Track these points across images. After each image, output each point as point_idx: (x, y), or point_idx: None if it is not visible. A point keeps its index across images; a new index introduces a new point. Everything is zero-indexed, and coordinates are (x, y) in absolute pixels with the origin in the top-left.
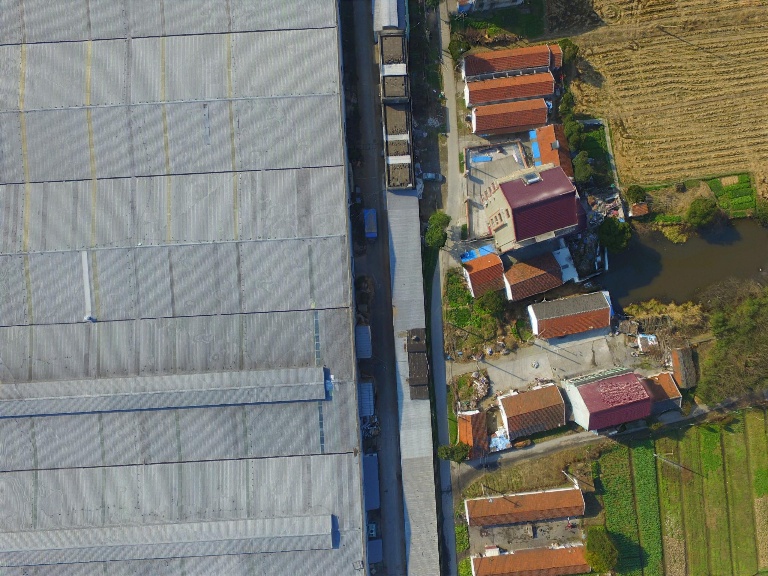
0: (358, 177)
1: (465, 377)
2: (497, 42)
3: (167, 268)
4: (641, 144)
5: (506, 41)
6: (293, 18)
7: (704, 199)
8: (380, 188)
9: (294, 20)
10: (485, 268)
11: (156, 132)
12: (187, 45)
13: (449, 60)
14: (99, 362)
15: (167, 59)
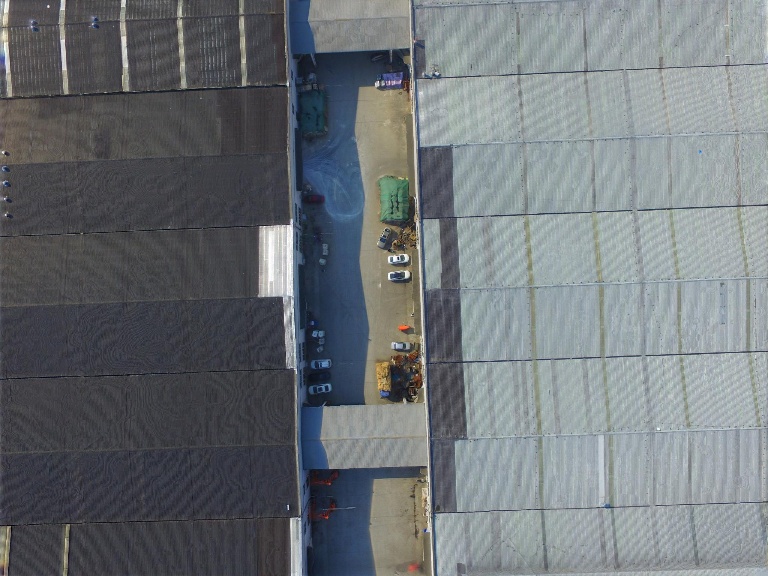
0: None
1: None
2: None
3: (686, 454)
4: None
5: None
6: None
7: None
8: None
9: None
10: None
11: (670, 310)
12: (696, 219)
13: None
14: (617, 551)
15: (677, 234)
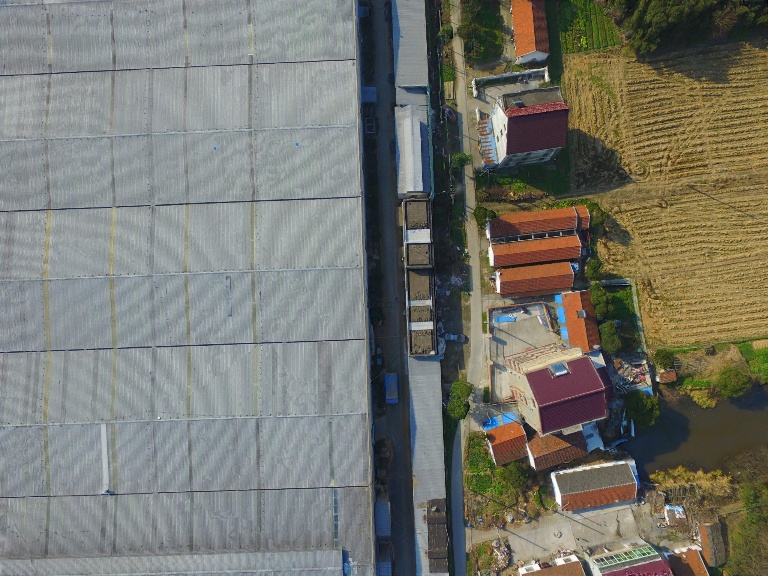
0: (379, 336)
1: (485, 545)
2: (522, 200)
3: (186, 442)
4: (669, 305)
5: (532, 198)
6: (317, 187)
7: (735, 373)
8: (401, 348)
9: (318, 189)
10: (508, 439)
11: (178, 303)
12: (211, 214)
13: (473, 217)
14: (115, 537)
15: (190, 228)
